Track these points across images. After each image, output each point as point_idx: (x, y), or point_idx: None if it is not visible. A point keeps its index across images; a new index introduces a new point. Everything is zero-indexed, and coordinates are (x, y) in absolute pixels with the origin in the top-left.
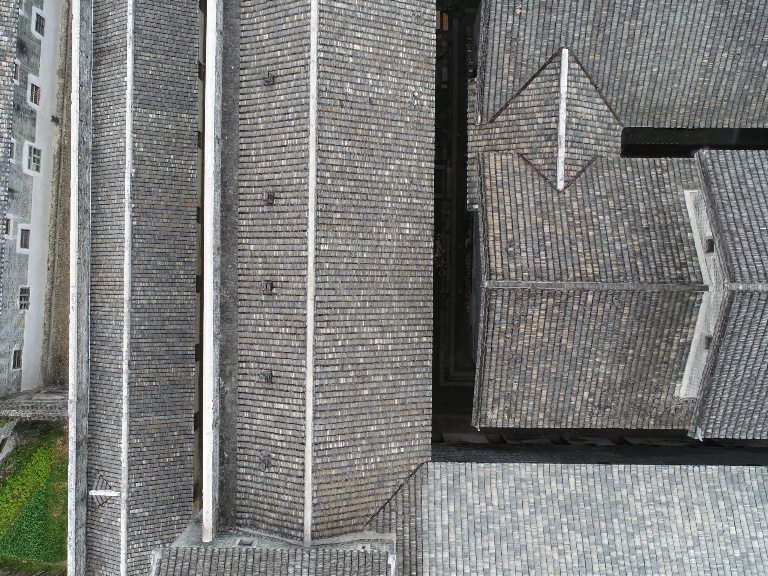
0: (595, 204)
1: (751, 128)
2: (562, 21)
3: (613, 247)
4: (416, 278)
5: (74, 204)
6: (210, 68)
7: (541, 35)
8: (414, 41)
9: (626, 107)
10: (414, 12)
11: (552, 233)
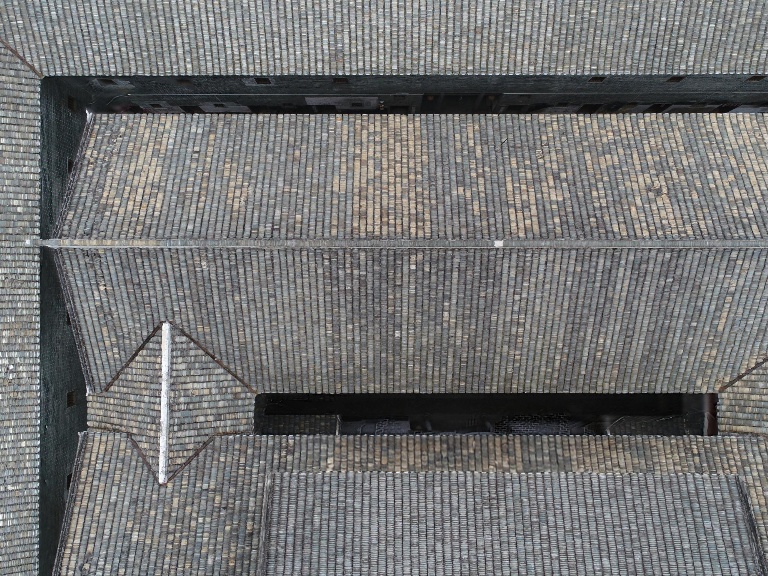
0: (199, 501)
1: (400, 393)
2: (156, 296)
3: (204, 561)
4: (13, 574)
5: None
6: None
7: (137, 309)
8: (8, 308)
9: (255, 374)
10: (8, 275)
11: (139, 543)
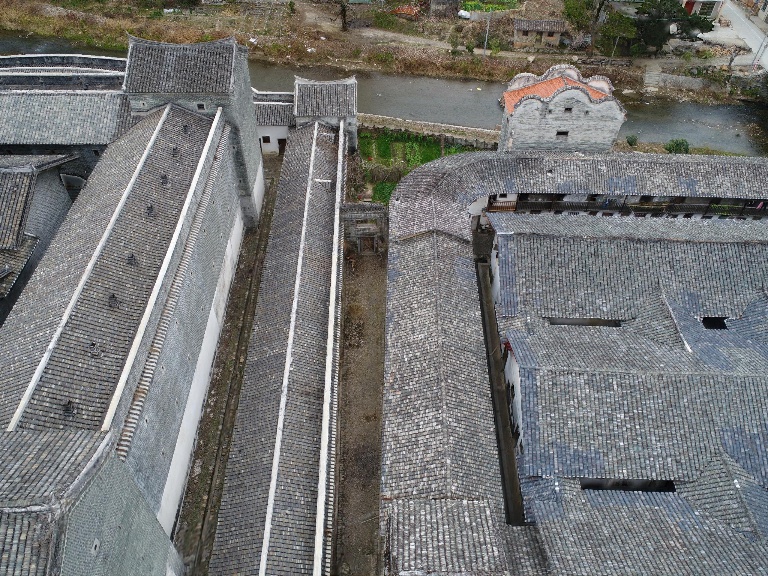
0: None
1: None
2: None
3: None
4: None
5: (332, 293)
6: (166, 259)
7: None
8: None
9: None
10: None
11: None
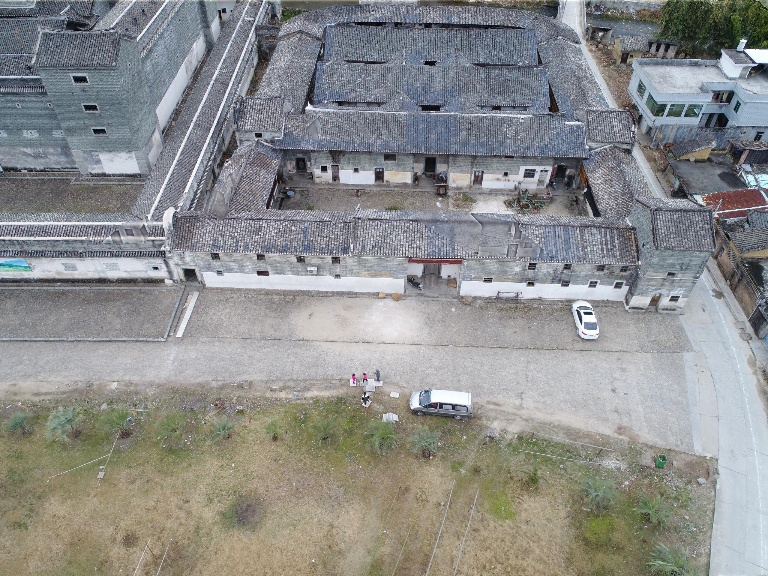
0: (61, 3)
1: None
2: None
3: None
4: None
5: None
6: (159, 11)
7: None
8: None
9: None
10: None
11: None
